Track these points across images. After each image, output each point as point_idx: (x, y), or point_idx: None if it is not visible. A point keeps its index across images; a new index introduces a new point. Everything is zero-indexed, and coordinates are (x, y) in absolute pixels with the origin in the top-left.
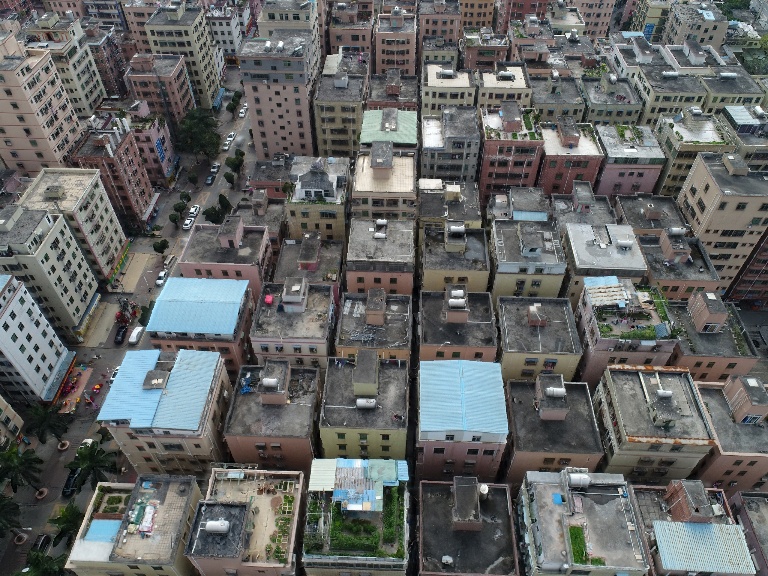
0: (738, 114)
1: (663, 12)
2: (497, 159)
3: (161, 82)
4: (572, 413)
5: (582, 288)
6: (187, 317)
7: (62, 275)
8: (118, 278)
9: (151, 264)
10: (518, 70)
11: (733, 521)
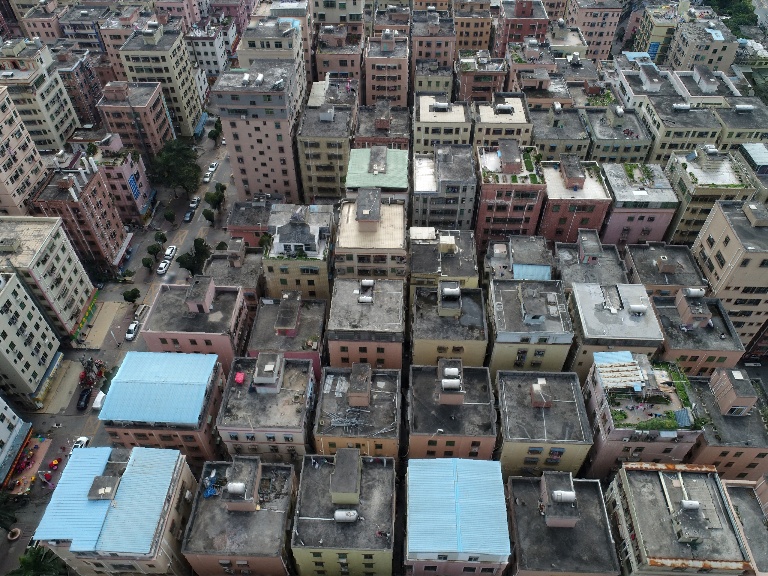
0: (757, 153)
1: (669, 31)
2: (495, 203)
3: (135, 113)
4: (583, 518)
5: (591, 357)
6: (146, 402)
7: (15, 340)
8: (84, 331)
9: (121, 314)
10: (517, 102)
11: None
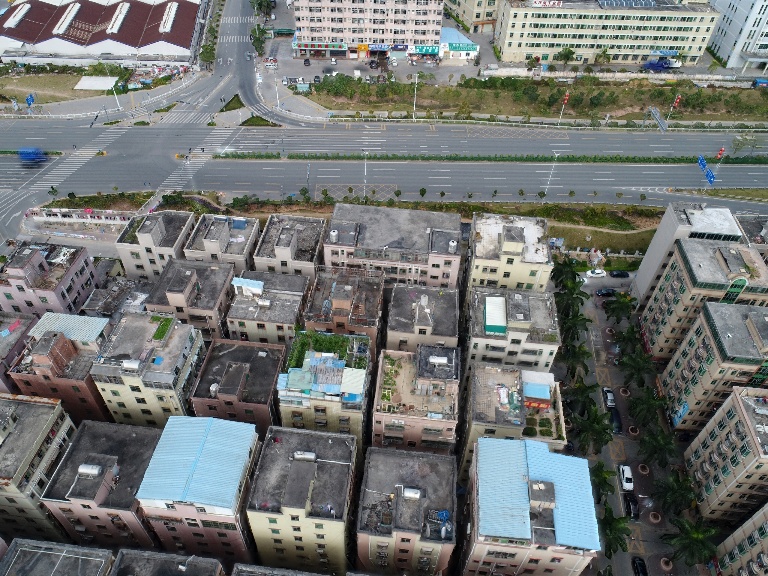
0: None
1: None
2: None
3: None
4: None
5: None
6: None
7: None
8: None
9: None
10: None
11: (24, 351)
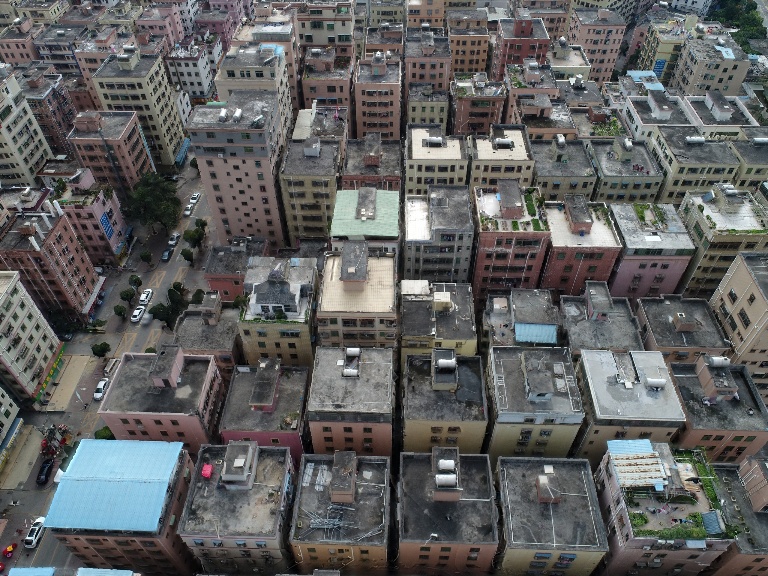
0: None
1: (675, 47)
2: (494, 251)
3: (108, 145)
4: None
5: (603, 437)
6: (98, 505)
7: None
8: (49, 390)
9: (90, 370)
10: (517, 135)
11: None
